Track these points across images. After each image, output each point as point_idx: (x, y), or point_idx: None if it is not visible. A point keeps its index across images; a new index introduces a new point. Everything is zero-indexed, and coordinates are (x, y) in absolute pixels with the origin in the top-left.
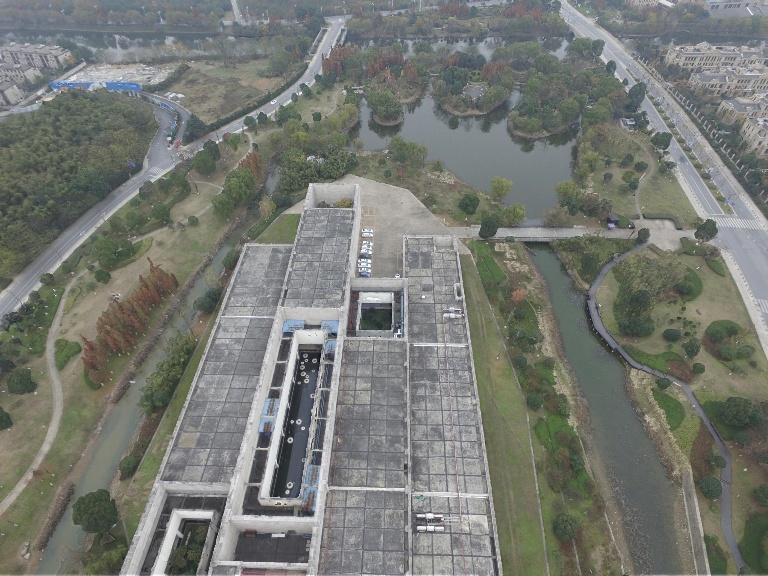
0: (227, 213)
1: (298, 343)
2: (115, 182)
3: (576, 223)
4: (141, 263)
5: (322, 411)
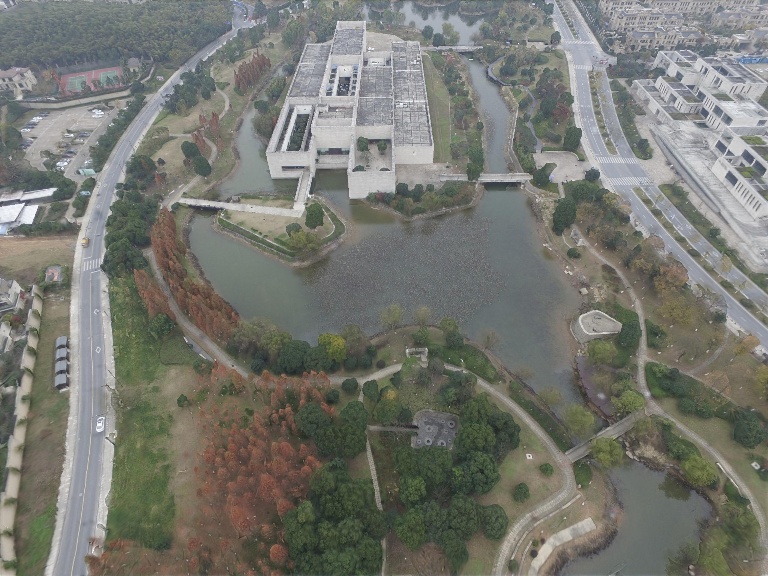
0: (289, 43)
1: (339, 76)
2: (220, 32)
3: None
4: (248, 59)
5: None
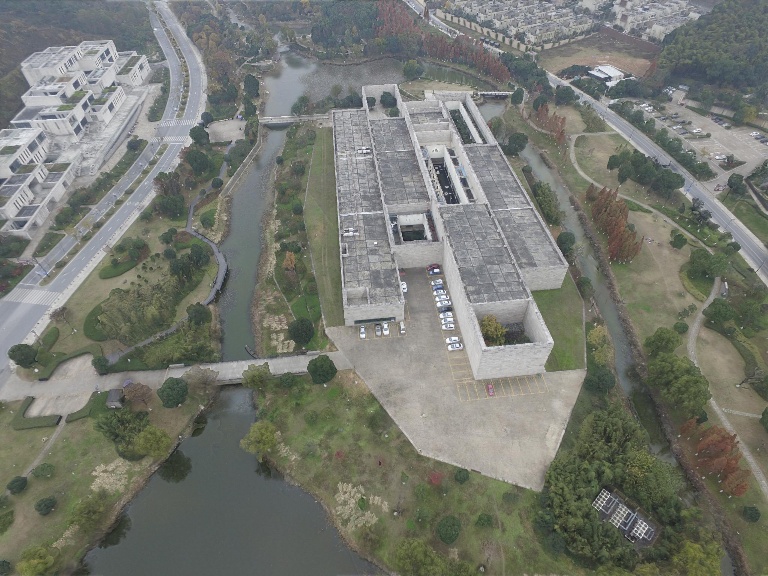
0: None
1: None
2: None
3: None
4: (671, 271)
5: None
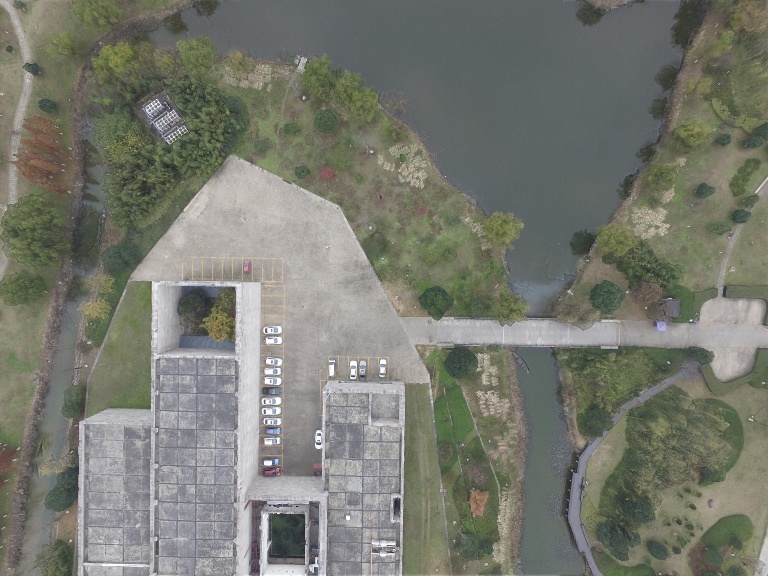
0: None
1: None
2: None
3: None
4: None
5: None
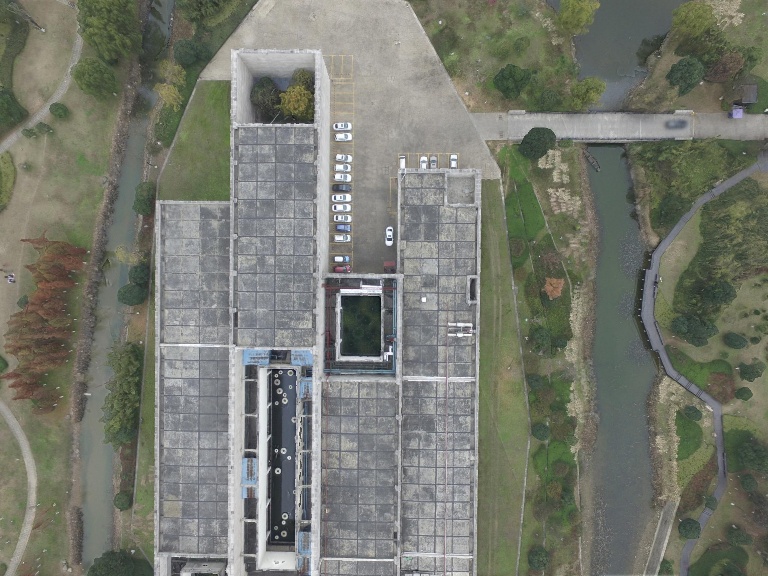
0: None
1: None
2: None
3: (682, 100)
4: (16, 211)
5: (306, 460)
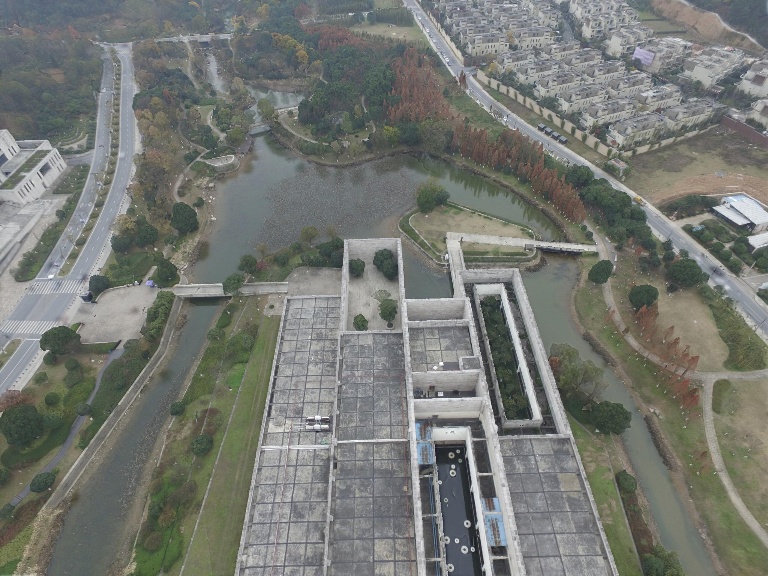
0: None
1: None
2: None
3: None
4: None
5: (435, 544)
